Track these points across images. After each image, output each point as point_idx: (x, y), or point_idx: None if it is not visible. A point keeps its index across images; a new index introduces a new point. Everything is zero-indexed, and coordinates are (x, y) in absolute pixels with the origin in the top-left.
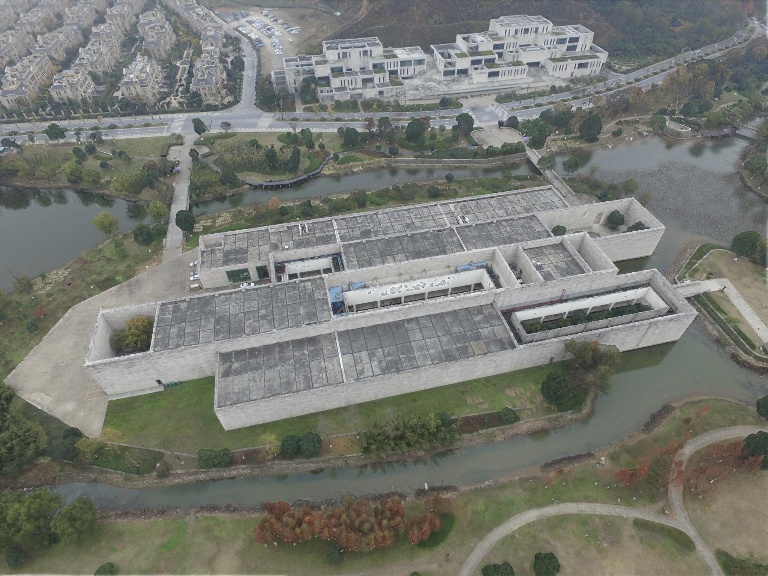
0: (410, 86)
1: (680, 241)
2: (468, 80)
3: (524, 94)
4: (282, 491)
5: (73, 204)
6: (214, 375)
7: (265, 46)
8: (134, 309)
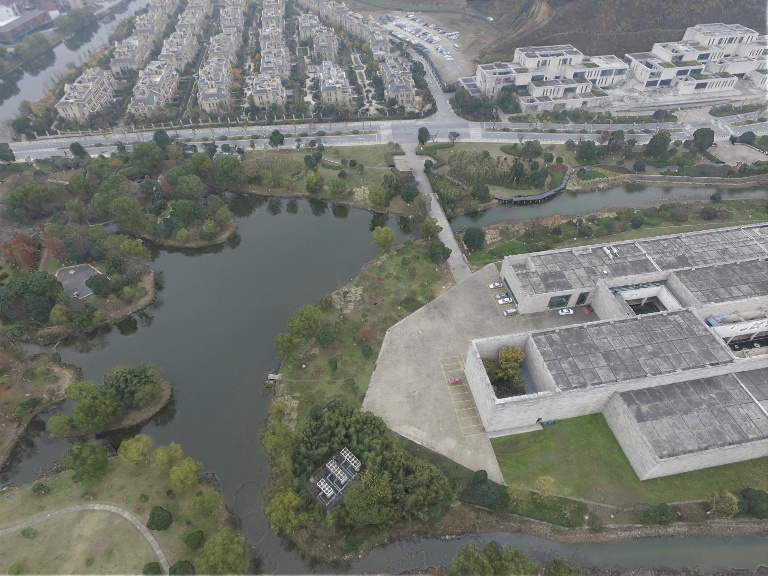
0: (615, 97)
1: None
2: (674, 91)
3: (738, 107)
4: (728, 554)
5: (303, 214)
6: (589, 414)
7: (430, 51)
8: (505, 339)
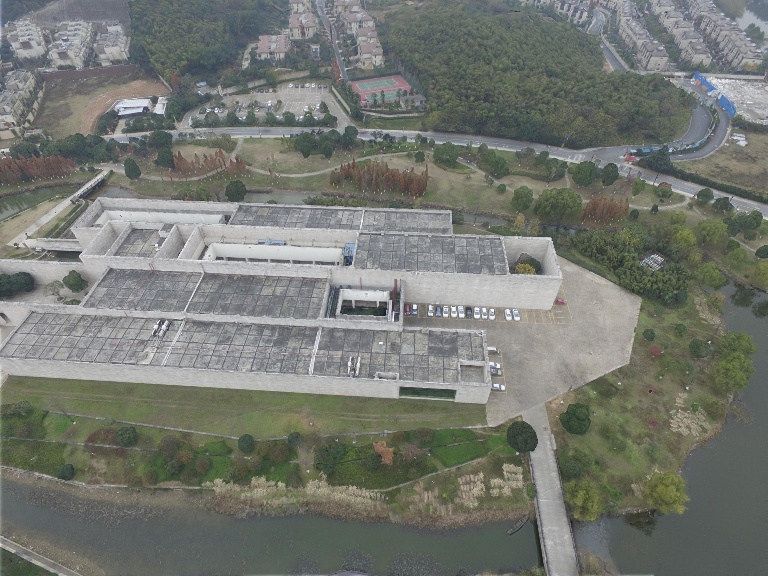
0: None
1: None
2: None
3: None
4: None
5: None
6: None
7: None
8: None
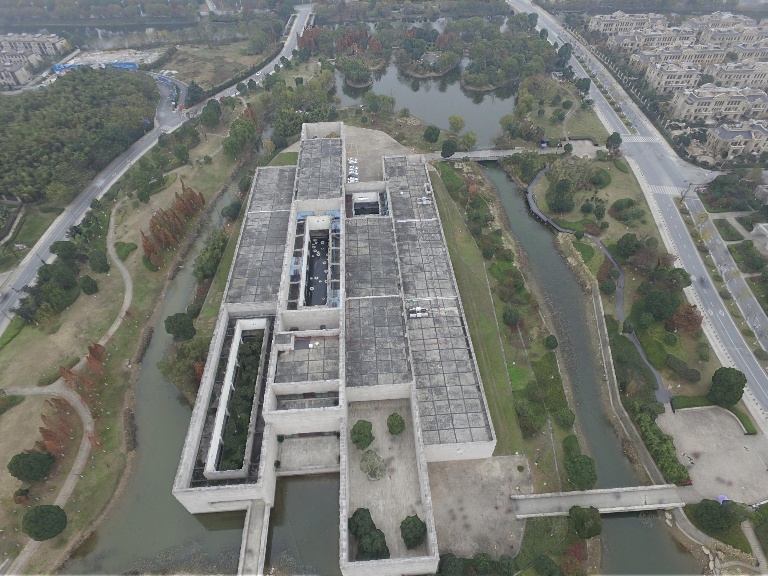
0: None
1: None
2: None
3: None
4: None
5: None
6: None
7: None
8: None
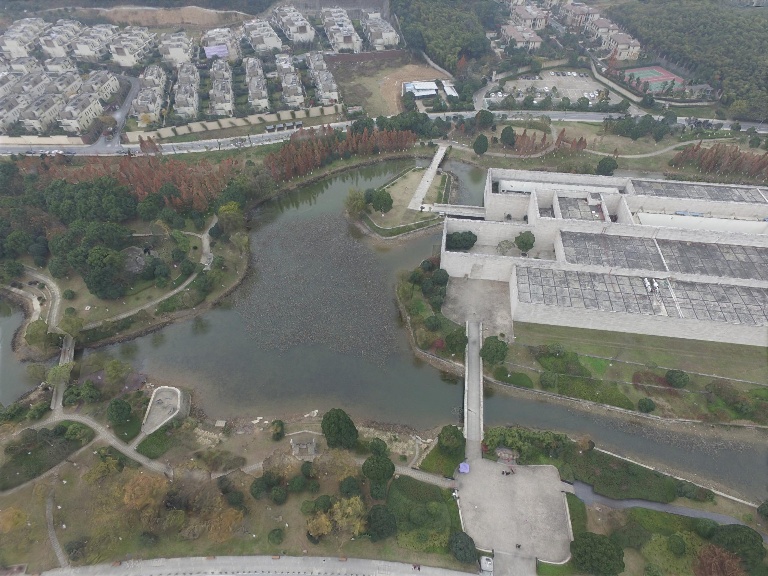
0: None
1: (398, 250)
2: None
3: None
4: None
5: None
6: None
7: None
8: None
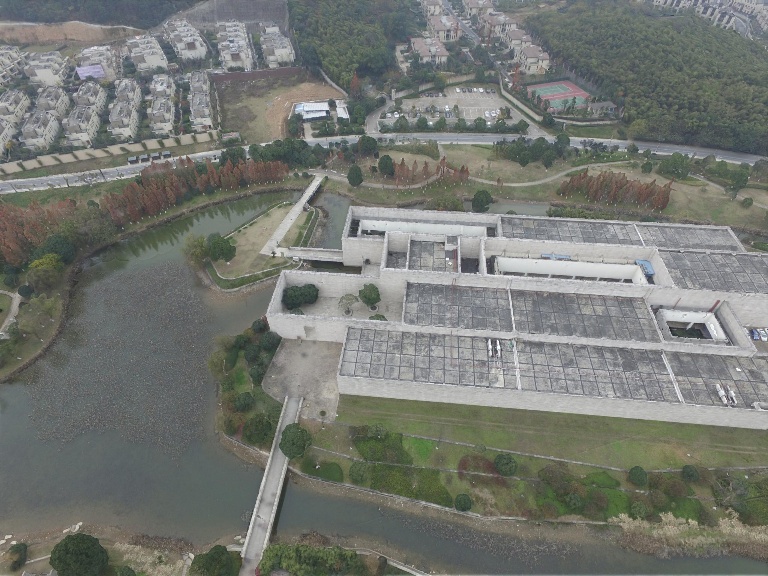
0: None
1: (238, 305)
2: None
3: None
4: None
5: None
6: None
7: None
8: None
